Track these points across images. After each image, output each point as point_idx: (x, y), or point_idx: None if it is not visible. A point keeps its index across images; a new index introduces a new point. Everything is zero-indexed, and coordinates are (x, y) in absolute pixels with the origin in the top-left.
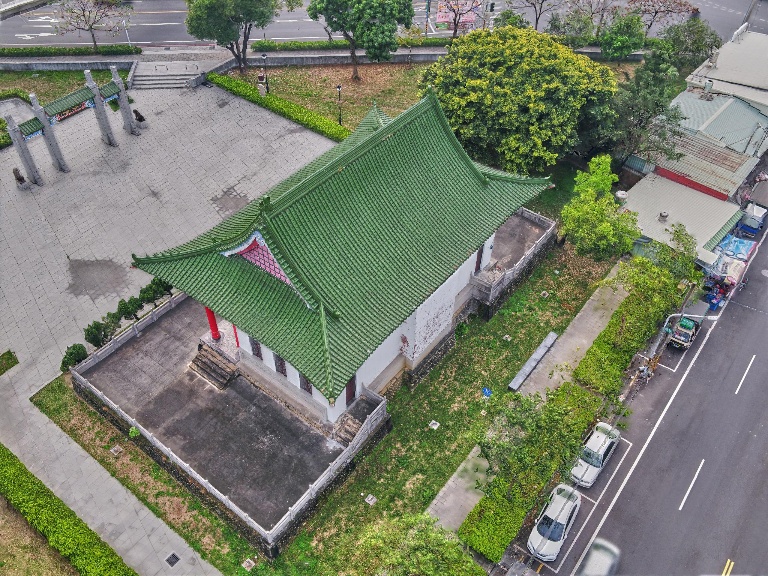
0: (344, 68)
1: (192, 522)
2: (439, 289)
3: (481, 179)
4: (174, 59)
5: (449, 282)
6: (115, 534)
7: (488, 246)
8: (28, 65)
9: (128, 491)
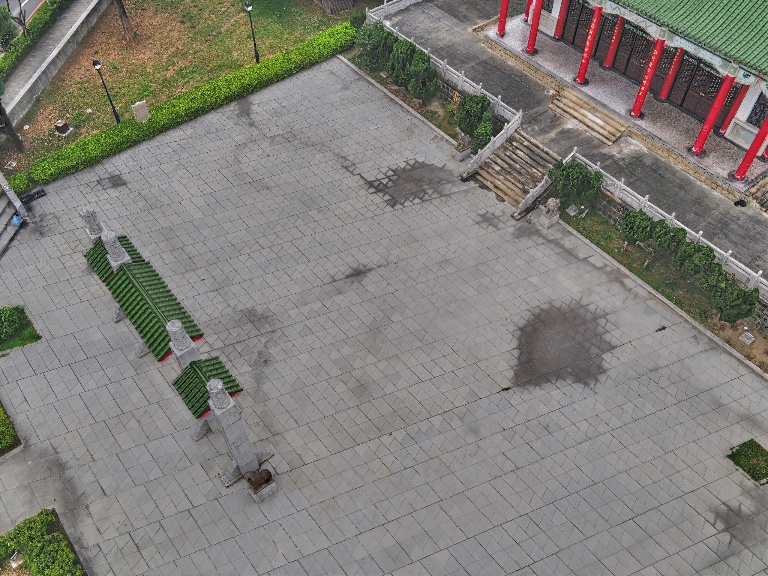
0: (92, 45)
1: None
2: None
3: None
4: None
5: None
6: None
7: None
8: None
9: None
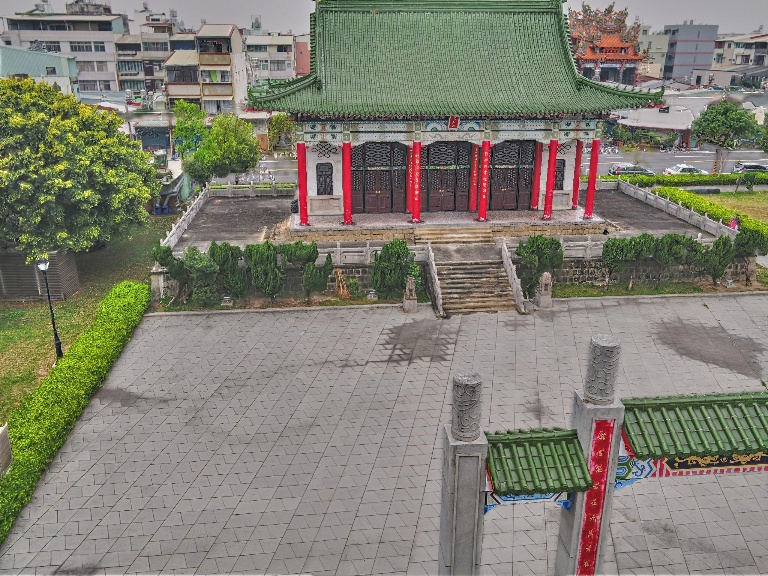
0: None
1: None
2: None
3: None
4: None
5: None
6: None
7: None
8: None
9: None
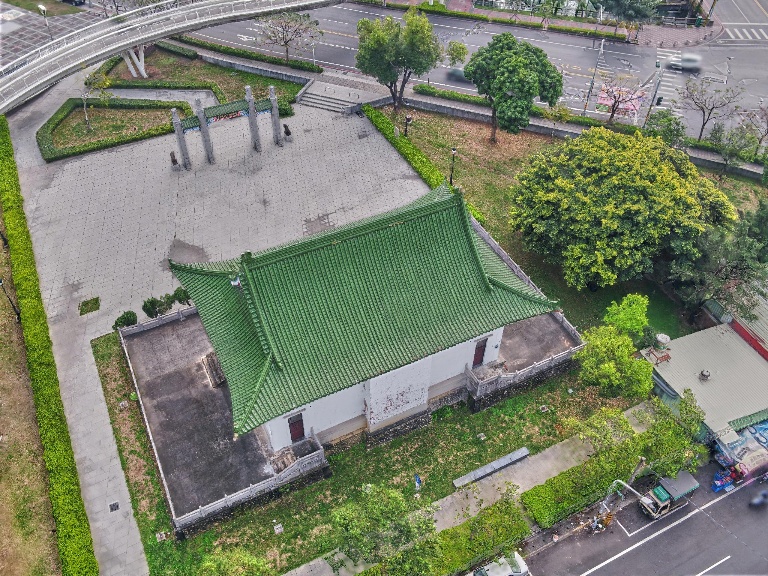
0: (488, 127)
1: (142, 484)
2: (402, 371)
3: (486, 284)
4: (345, 84)
5: (417, 368)
6: (89, 469)
7: (492, 345)
8: (232, 64)
9: (114, 440)
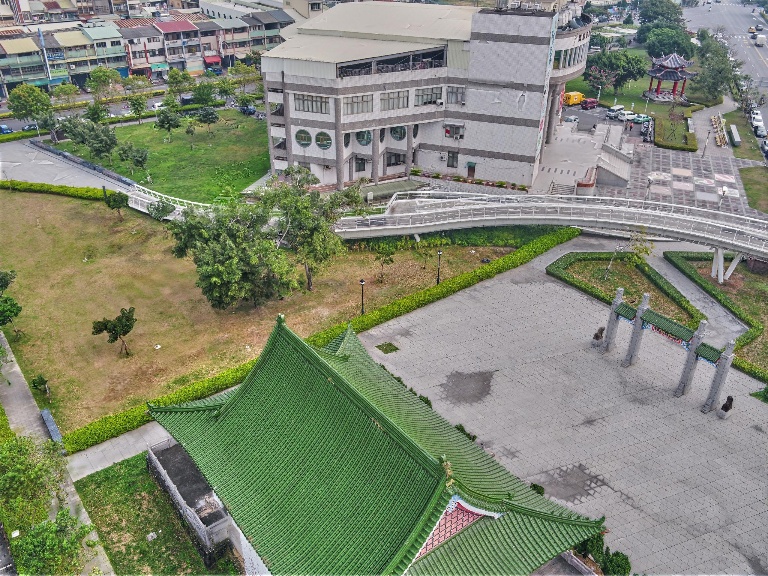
0: None
1: None
2: None
3: None
4: None
5: None
6: None
7: None
8: None
9: None
